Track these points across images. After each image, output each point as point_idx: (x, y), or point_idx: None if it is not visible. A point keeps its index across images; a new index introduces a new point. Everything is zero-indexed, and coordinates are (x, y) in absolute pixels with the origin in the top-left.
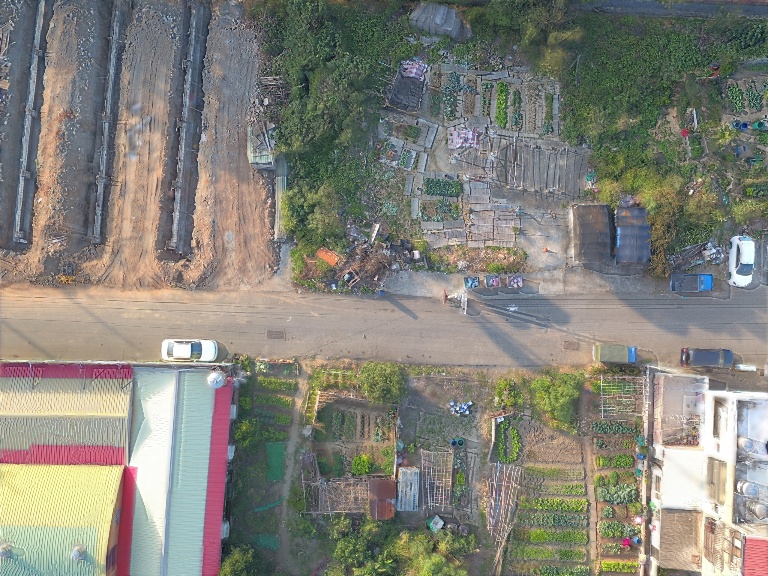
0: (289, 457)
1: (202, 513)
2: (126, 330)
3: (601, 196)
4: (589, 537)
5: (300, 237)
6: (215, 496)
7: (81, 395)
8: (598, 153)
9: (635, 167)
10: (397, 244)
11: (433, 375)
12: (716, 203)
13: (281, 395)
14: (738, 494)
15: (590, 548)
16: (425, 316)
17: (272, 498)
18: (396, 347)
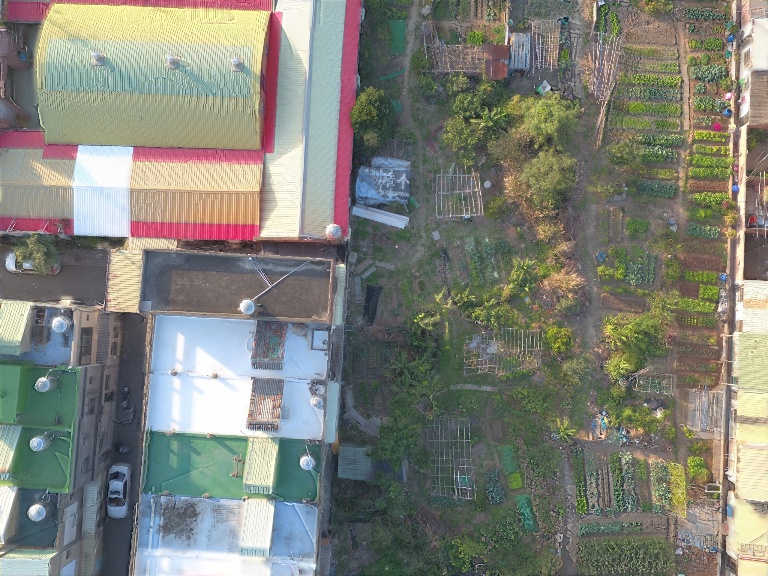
0: (410, 34)
1: (340, 52)
2: None
3: None
4: (682, 110)
5: None
6: (351, 40)
7: None
8: None
9: None
10: None
11: None
12: None
13: None
14: None
15: (683, 120)
16: None
17: (395, 69)
18: None
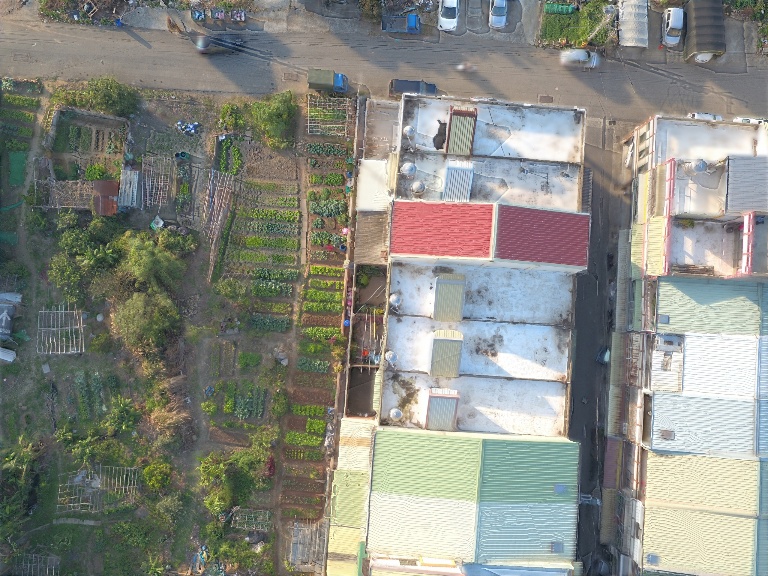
0: (29, 165)
1: None
2: None
3: None
4: (300, 244)
5: None
6: None
7: None
8: None
9: None
10: None
11: (163, 98)
12: None
13: (24, 111)
14: (399, 173)
15: (300, 254)
16: (158, 46)
17: (12, 200)
18: (130, 72)
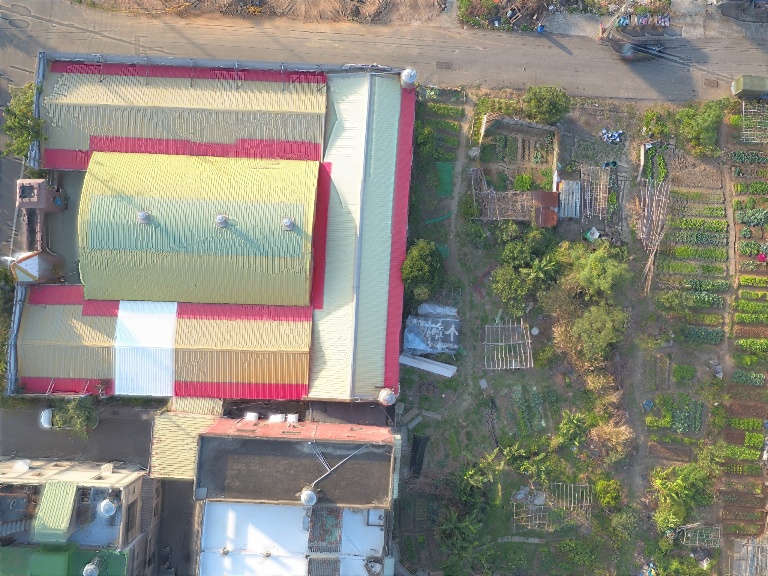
0: (456, 176)
1: (390, 205)
2: (308, 57)
3: None
4: (728, 255)
5: None
6: (401, 191)
7: (278, 99)
8: None
9: None
10: None
11: (587, 106)
12: None
13: (449, 120)
14: None
15: (729, 265)
16: (579, 53)
17: (441, 212)
18: (553, 79)
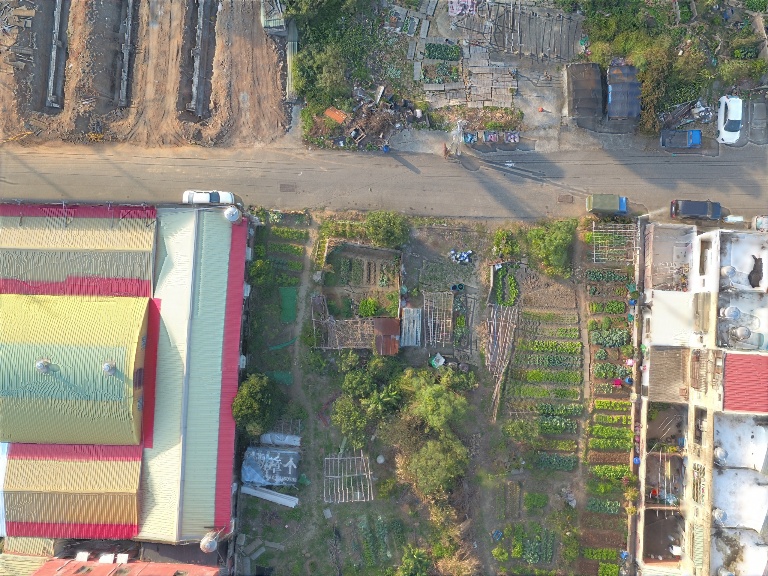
0: (301, 301)
1: (220, 341)
2: (150, 184)
3: (594, 57)
4: (583, 377)
5: (310, 98)
6: (232, 326)
7: (109, 235)
8: (592, 19)
9: (627, 31)
10: (401, 105)
11: (435, 226)
12: (705, 63)
13: (293, 244)
14: (720, 318)
15: (584, 388)
16: (427, 171)
17: (285, 338)
18: (400, 200)
